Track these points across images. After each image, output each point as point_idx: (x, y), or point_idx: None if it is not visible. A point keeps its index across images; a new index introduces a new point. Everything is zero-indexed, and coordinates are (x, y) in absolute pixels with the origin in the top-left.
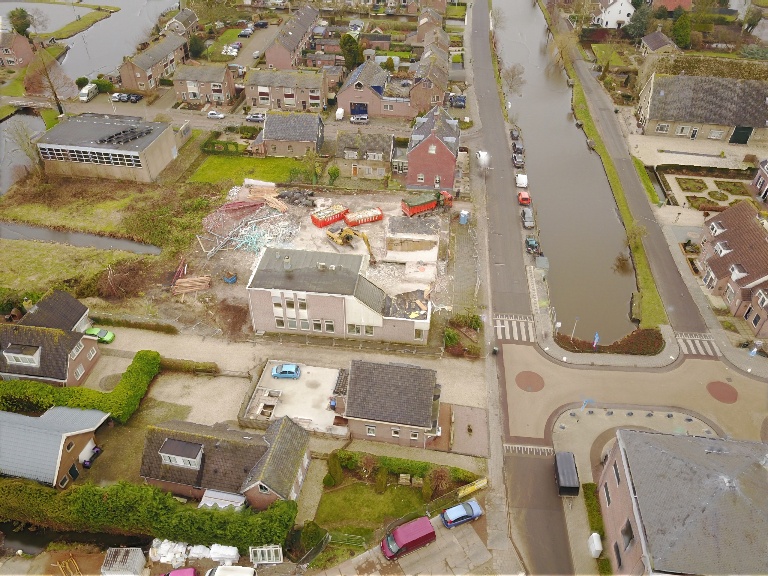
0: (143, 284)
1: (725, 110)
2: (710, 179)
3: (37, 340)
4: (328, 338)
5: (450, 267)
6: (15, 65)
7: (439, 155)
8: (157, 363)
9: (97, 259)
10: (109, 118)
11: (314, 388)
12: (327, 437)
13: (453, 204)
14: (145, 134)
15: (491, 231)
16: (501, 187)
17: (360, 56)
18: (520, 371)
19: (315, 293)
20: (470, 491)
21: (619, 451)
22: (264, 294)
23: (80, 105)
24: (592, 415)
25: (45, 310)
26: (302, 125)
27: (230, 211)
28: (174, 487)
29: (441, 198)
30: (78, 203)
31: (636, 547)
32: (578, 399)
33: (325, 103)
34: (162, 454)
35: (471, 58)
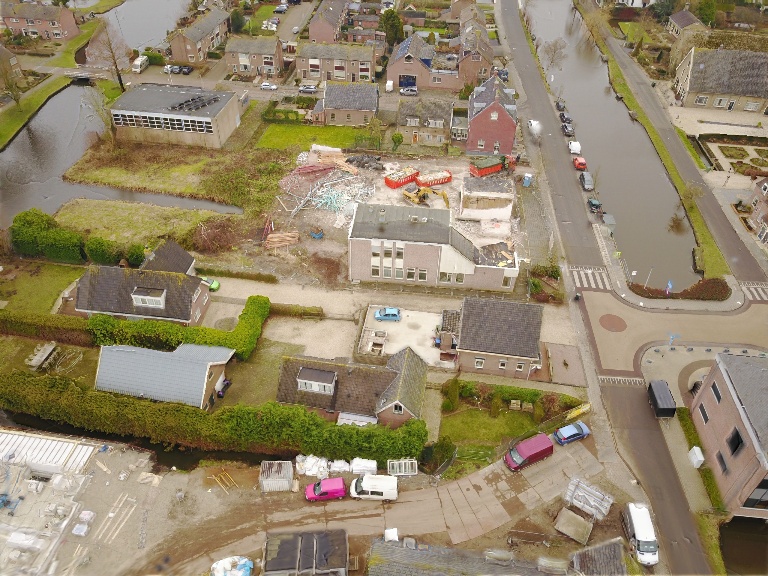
0: (234, 240)
1: (761, 83)
2: (750, 147)
3: (162, 283)
4: (420, 286)
5: (521, 224)
6: (61, 38)
7: (501, 122)
8: (268, 307)
9: (185, 217)
10: None
11: (416, 329)
12: (436, 370)
13: None
14: (213, 102)
15: (553, 193)
16: (556, 154)
17: (401, 31)
18: (603, 314)
19: (414, 242)
20: (576, 414)
21: (720, 372)
22: (365, 244)
23: (139, 75)
24: (674, 351)
25: (161, 258)
26: (361, 94)
27: (303, 174)
28: (308, 412)
29: (506, 161)
30: (154, 167)
31: (748, 448)
32: (659, 338)
33: (373, 76)
34: (300, 380)
35: (505, 35)
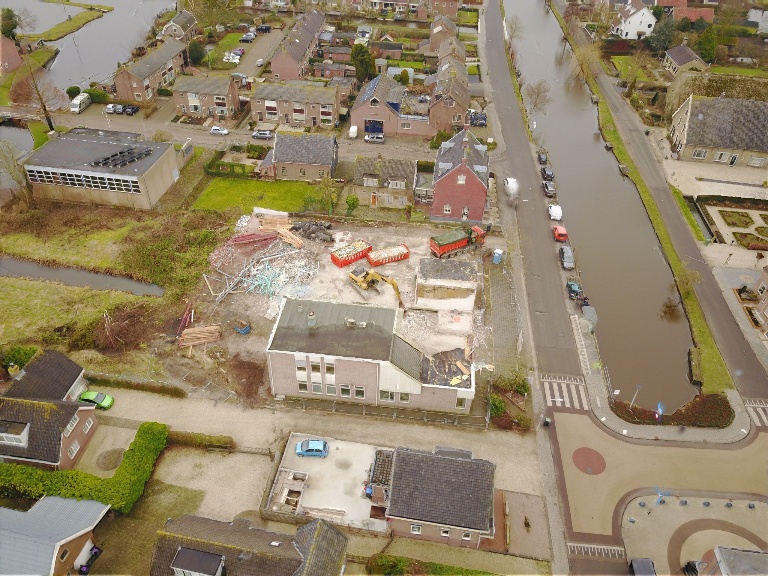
0: (145, 333)
1: (767, 136)
2: (755, 212)
3: (25, 416)
4: (357, 404)
5: (487, 316)
6: None
7: (469, 186)
8: (164, 438)
9: (92, 302)
10: (103, 134)
11: (345, 469)
12: (364, 534)
13: (484, 240)
14: (144, 156)
15: (528, 272)
16: (533, 219)
17: (372, 67)
18: (577, 447)
19: (346, 358)
20: None
21: (720, 575)
22: (287, 357)
23: None
24: (664, 505)
25: (34, 375)
26: (316, 147)
27: (239, 245)
28: None
29: (473, 235)
30: (70, 233)
31: None
32: (645, 484)
33: (337, 119)
34: (175, 568)
35: (488, 70)
